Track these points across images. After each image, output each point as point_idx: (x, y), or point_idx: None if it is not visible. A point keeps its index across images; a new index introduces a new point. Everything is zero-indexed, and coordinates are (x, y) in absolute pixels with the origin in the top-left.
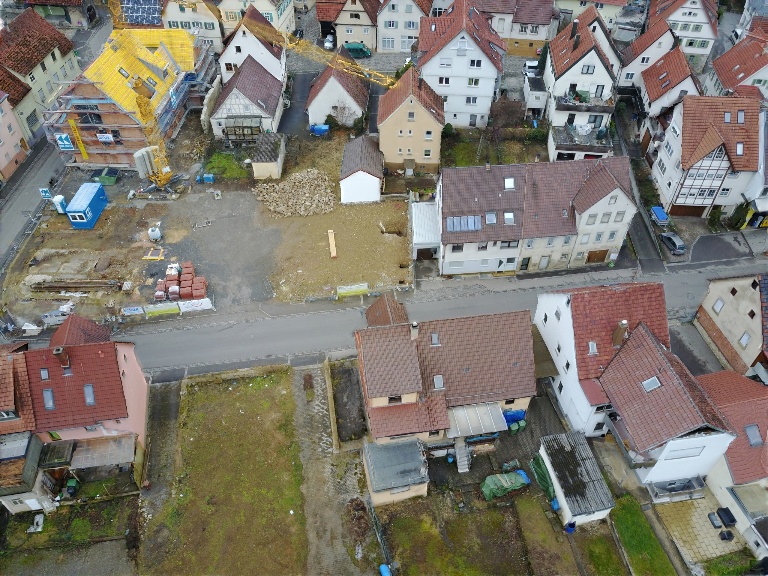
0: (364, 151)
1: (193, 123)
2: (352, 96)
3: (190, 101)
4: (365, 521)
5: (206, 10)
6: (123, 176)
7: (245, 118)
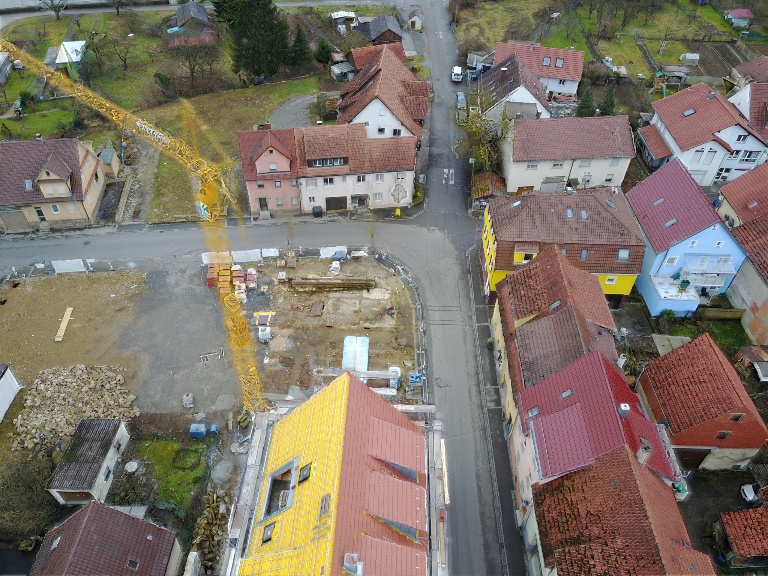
0: None
1: None
2: None
3: None
4: (126, 157)
5: None
6: None
7: None
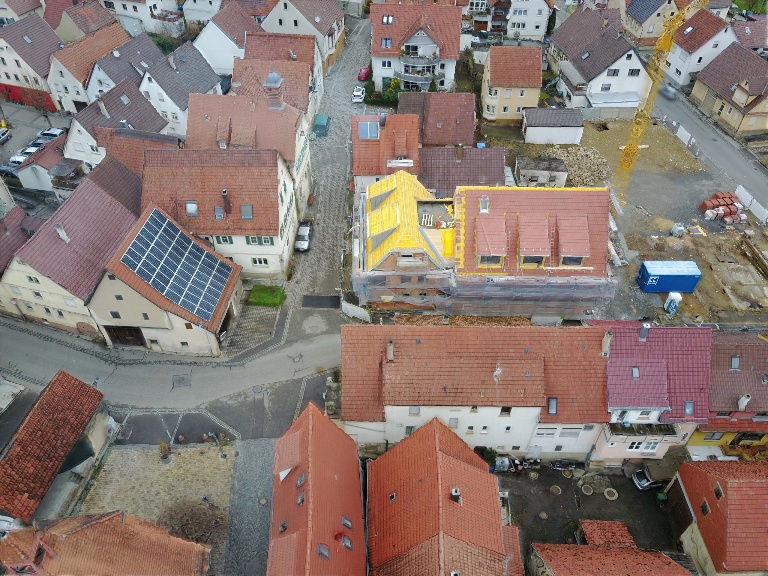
0: None
1: None
2: None
3: None
4: None
5: (288, 181)
6: None
7: None
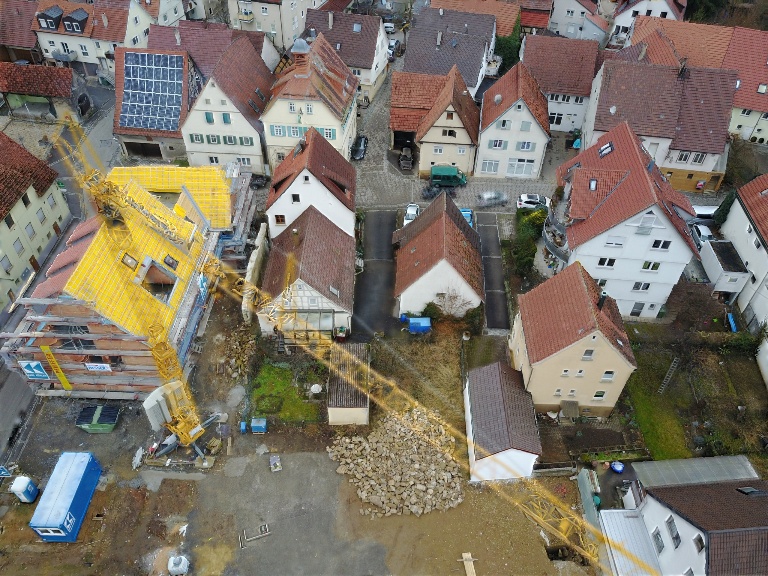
0: (507, 400)
1: (227, 298)
2: (469, 282)
3: (223, 265)
4: None
5: (243, 122)
6: (125, 412)
7: (309, 313)
